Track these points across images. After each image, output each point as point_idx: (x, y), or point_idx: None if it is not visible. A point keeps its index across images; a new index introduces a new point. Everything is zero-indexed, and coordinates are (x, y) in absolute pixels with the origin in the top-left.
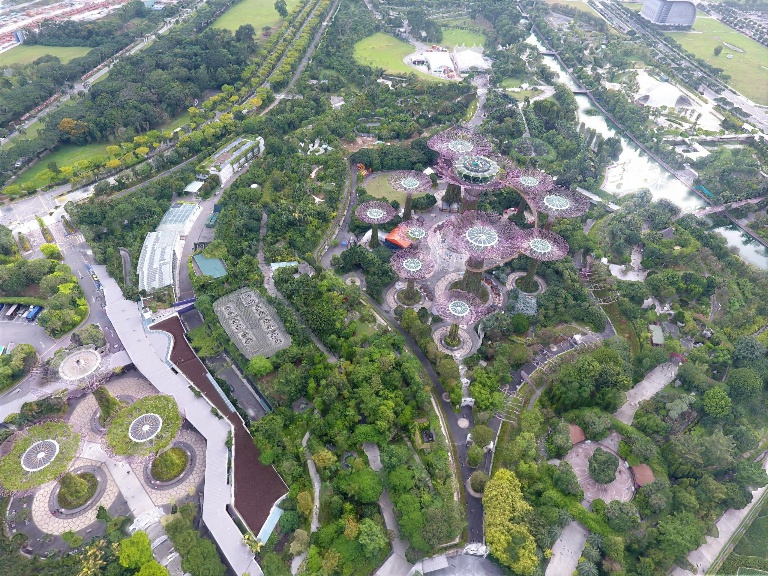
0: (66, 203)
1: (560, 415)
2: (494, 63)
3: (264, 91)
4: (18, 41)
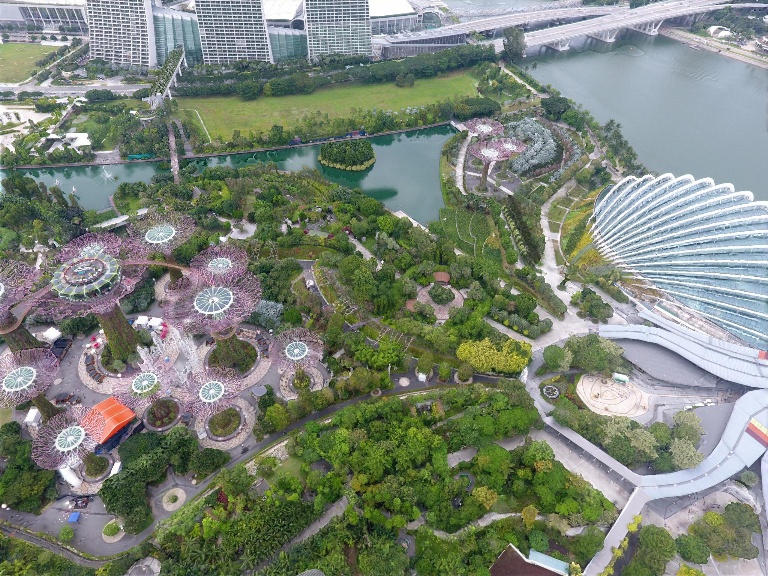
0: None
1: (398, 309)
2: None
3: None
4: None
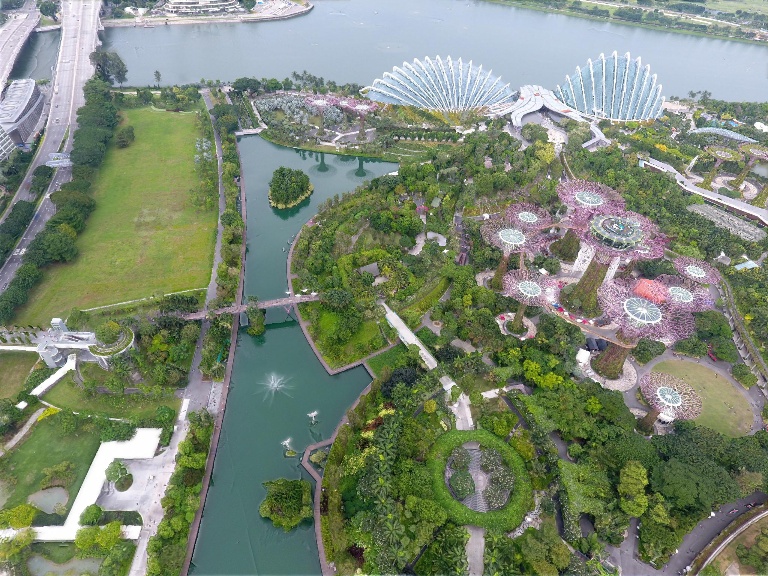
0: None
1: None
2: None
3: None
4: None
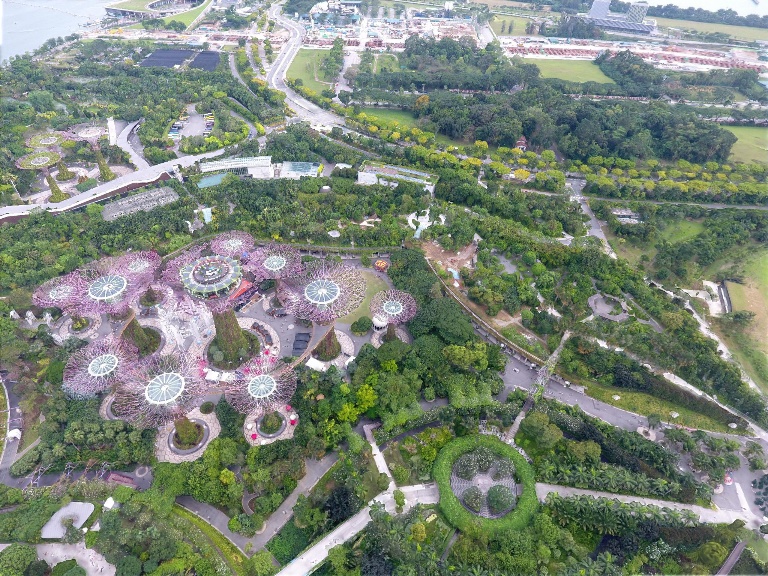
0: None
1: None
2: None
3: (550, 175)
4: (596, 58)
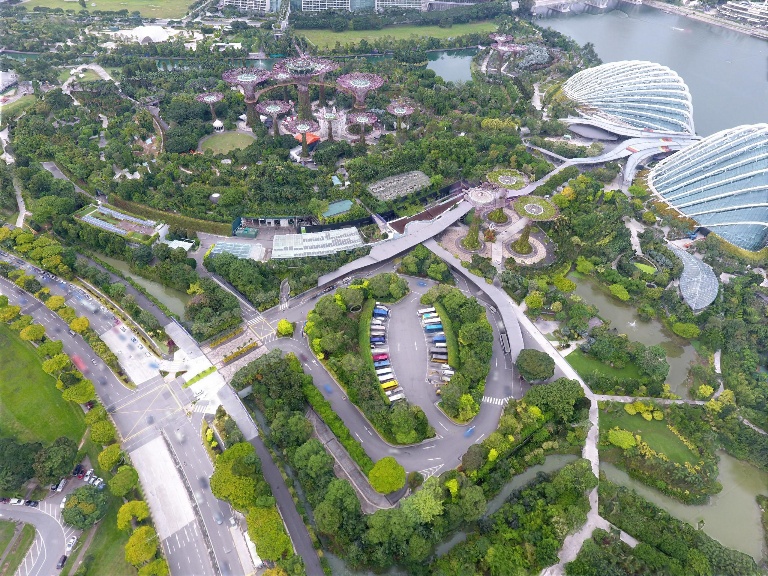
0: (198, 327)
1: None
2: (18, 69)
3: None
4: None
